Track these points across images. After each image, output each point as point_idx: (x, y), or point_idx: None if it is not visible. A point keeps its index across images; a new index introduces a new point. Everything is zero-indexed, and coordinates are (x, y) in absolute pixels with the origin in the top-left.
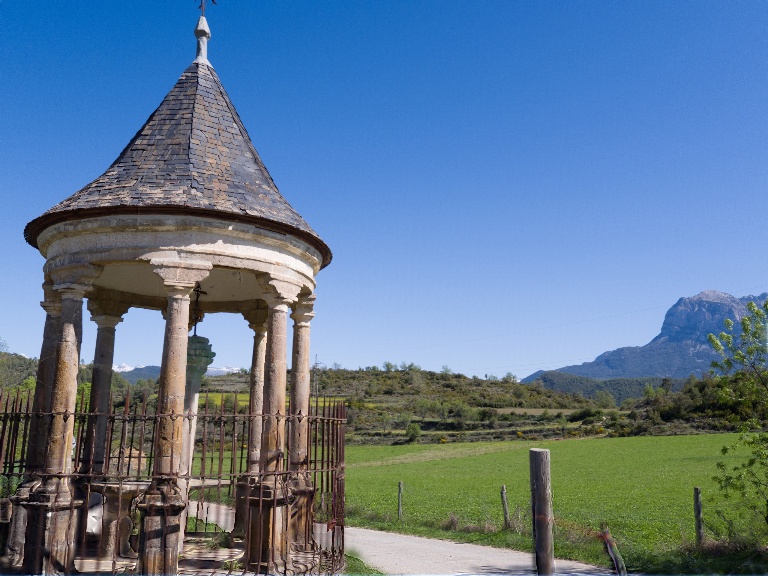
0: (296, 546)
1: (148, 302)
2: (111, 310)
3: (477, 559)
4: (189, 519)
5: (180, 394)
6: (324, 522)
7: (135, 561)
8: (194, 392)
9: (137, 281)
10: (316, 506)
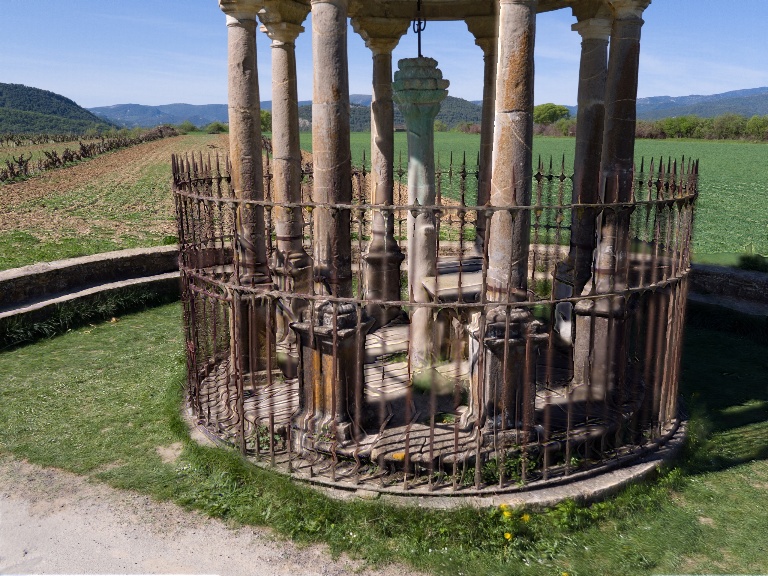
0: None
1: None
2: None
3: None
4: None
5: None
6: None
7: (403, 343)
8: None
9: None
10: None
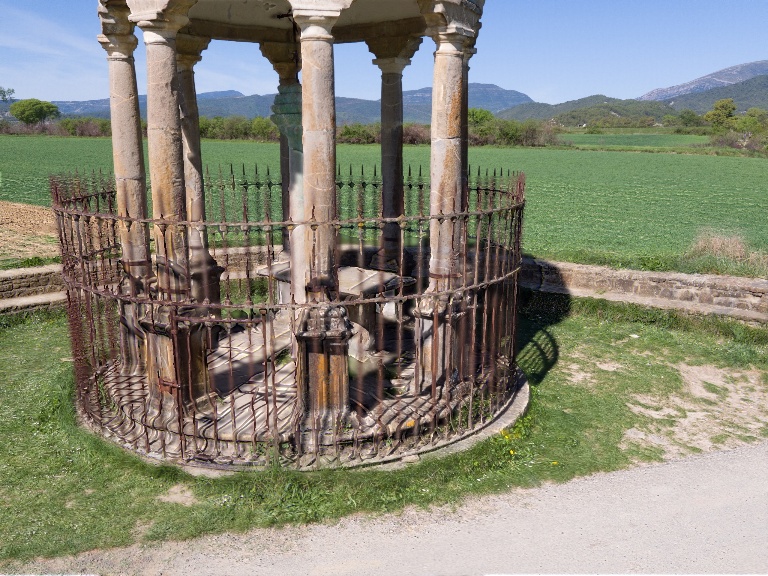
0: (294, 409)
1: (425, 25)
2: (388, 50)
3: None
4: None
5: (119, 176)
6: None
7: None
8: (292, 164)
9: (387, 3)
10: None
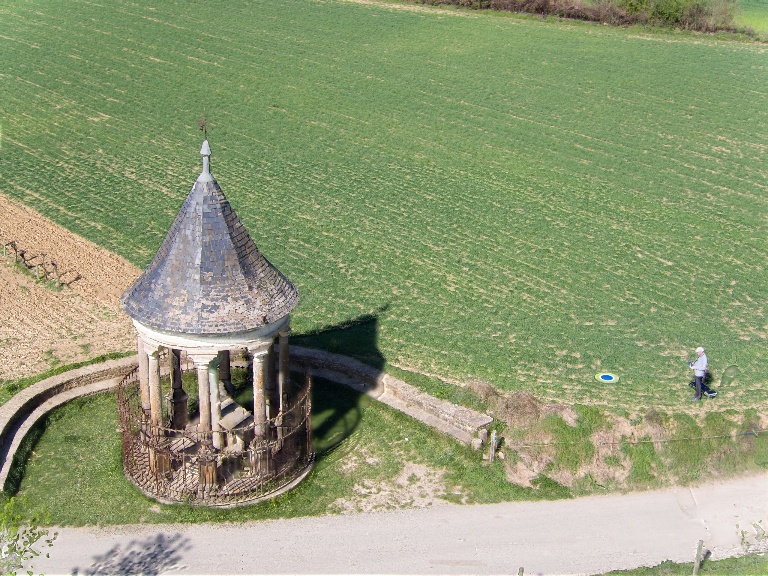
0: None
1: None
2: None
3: (218, 574)
4: (484, 469)
5: None
6: (607, 572)
7: None
8: None
9: None
10: (708, 570)
